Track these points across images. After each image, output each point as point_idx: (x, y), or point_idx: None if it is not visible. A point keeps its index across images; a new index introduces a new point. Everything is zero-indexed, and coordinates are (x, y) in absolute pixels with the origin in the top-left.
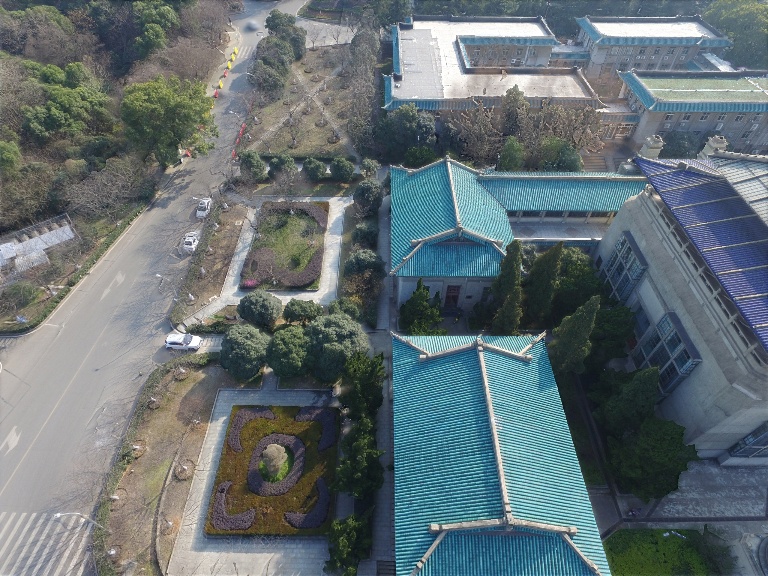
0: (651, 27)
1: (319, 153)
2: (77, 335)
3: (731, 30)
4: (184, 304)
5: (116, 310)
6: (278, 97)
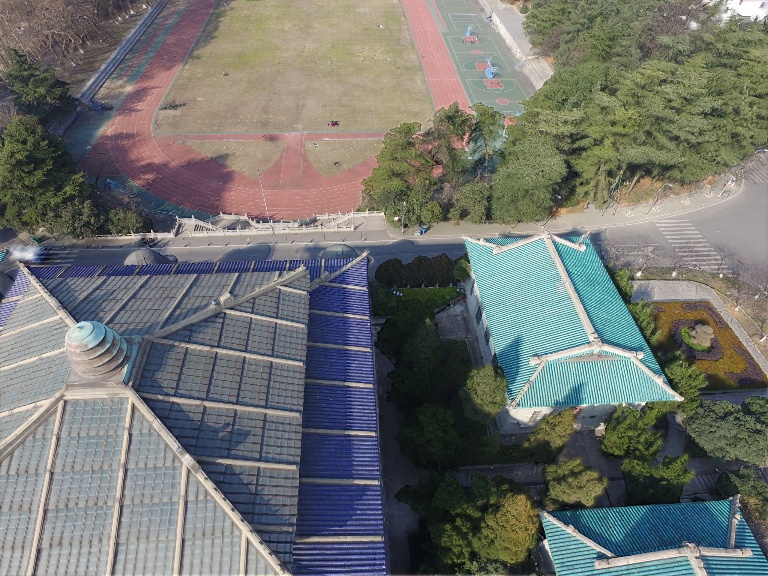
0: None
1: None
2: None
3: None
4: None
5: None
6: None
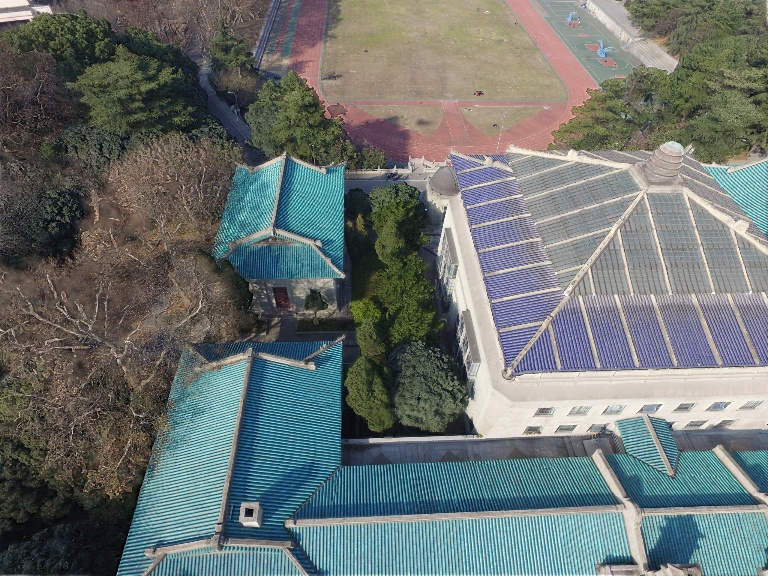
0: None
1: None
2: None
3: None
4: None
5: None
6: None
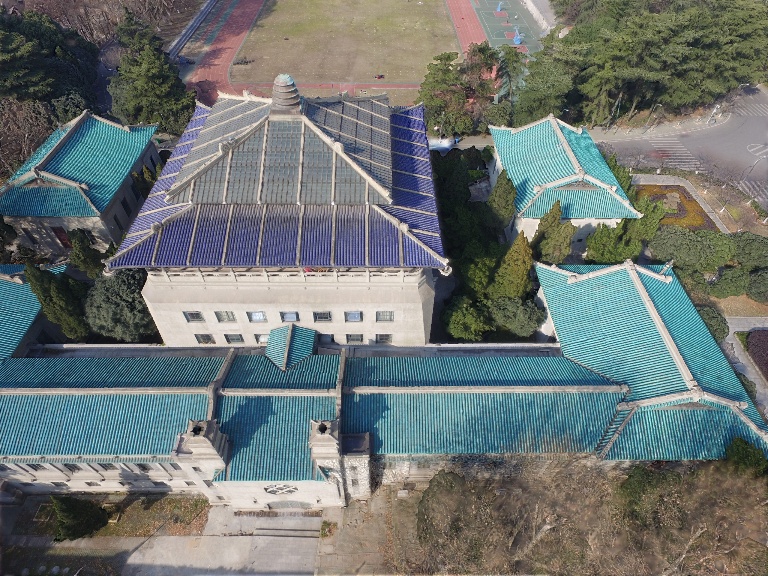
0: None
1: None
2: None
3: None
4: None
5: None
6: None
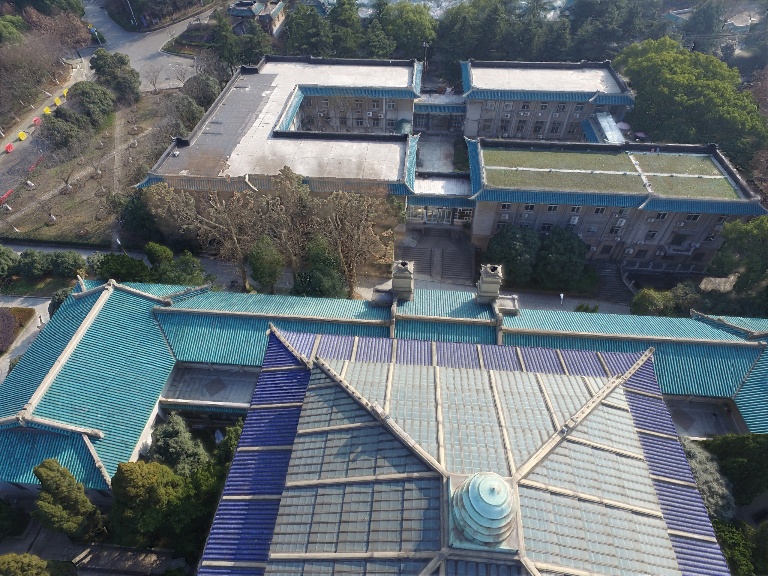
0: (545, 75)
1: (75, 234)
2: None
3: (633, 85)
4: None
5: None
6: (73, 155)
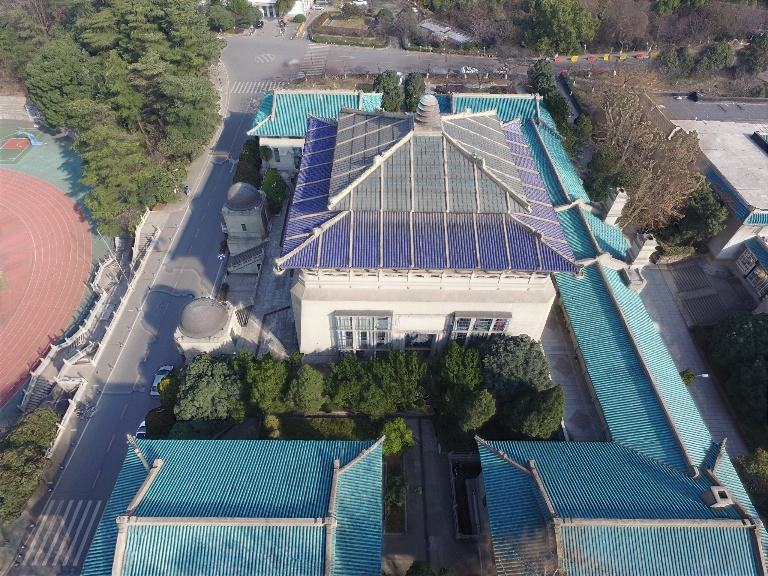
0: None
1: None
2: (403, 59)
3: None
4: (423, 76)
5: (419, 64)
6: None
